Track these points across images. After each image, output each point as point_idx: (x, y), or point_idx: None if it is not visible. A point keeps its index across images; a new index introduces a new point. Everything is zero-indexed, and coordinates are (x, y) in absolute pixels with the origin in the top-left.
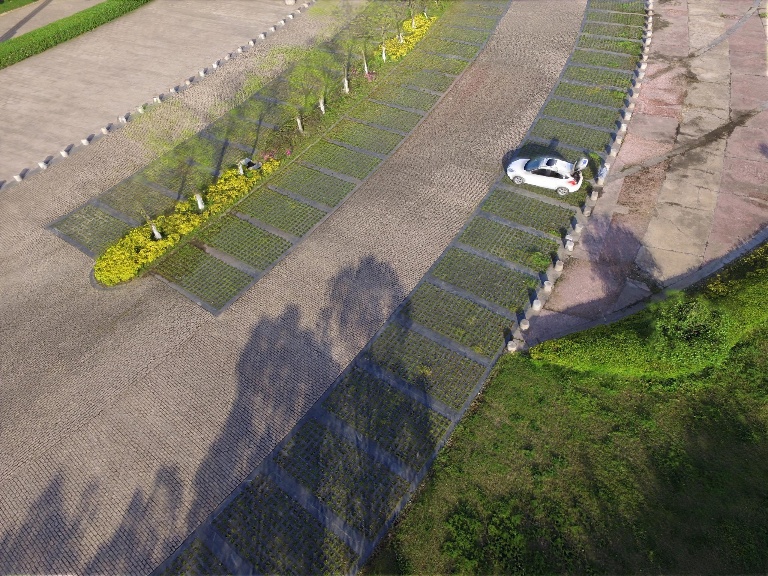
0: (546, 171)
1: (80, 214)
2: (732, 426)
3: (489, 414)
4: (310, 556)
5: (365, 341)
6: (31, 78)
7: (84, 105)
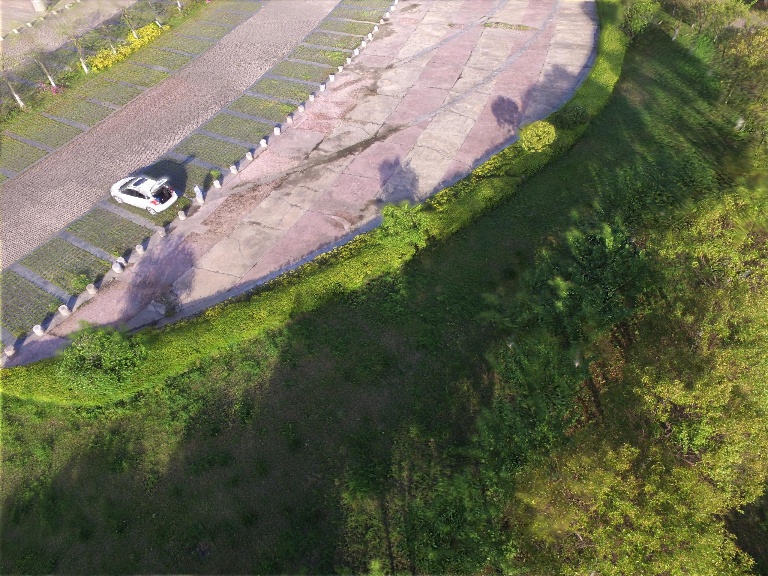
0: (132, 191)
1: None
2: (113, 454)
3: None
4: None
5: None
6: None
7: None
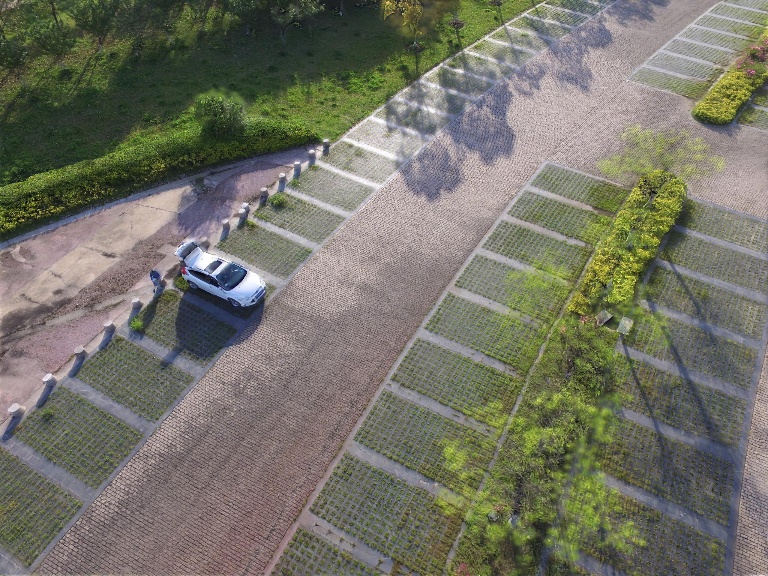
0: None
1: None
2: None
3: (351, 118)
4: (444, 78)
5: (427, 148)
6: None
7: None
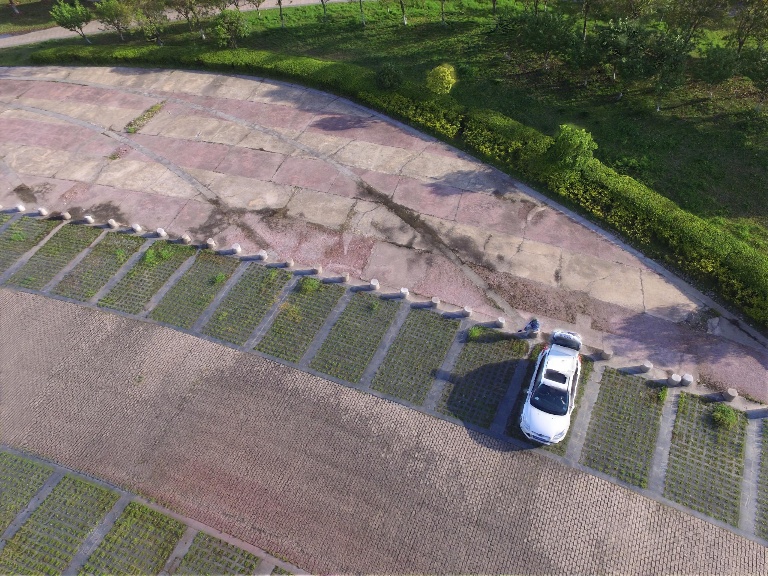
0: None
1: None
2: None
3: None
4: None
5: None
6: None
7: None
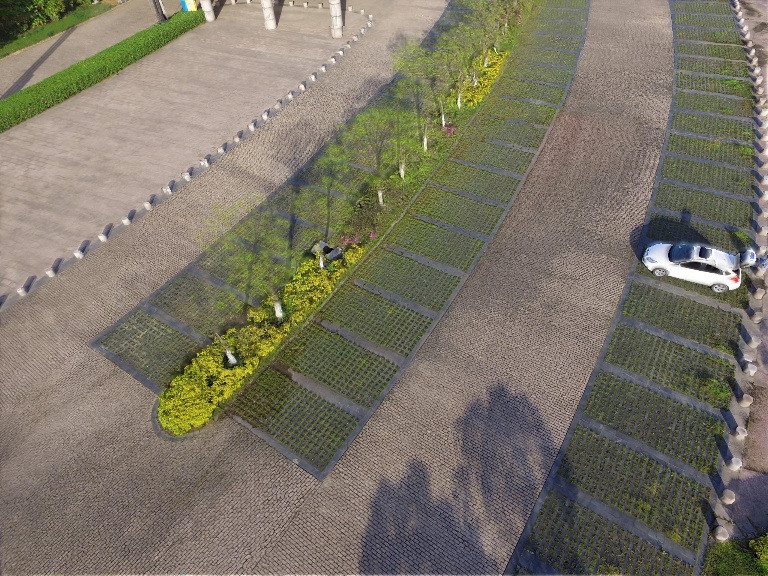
0: (700, 264)
1: (130, 324)
2: None
3: None
4: None
5: (522, 522)
6: (54, 135)
7: (119, 170)
